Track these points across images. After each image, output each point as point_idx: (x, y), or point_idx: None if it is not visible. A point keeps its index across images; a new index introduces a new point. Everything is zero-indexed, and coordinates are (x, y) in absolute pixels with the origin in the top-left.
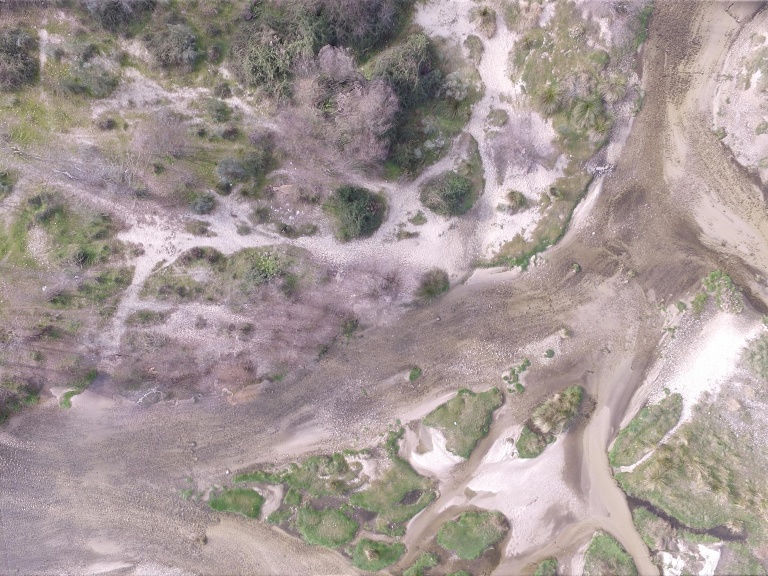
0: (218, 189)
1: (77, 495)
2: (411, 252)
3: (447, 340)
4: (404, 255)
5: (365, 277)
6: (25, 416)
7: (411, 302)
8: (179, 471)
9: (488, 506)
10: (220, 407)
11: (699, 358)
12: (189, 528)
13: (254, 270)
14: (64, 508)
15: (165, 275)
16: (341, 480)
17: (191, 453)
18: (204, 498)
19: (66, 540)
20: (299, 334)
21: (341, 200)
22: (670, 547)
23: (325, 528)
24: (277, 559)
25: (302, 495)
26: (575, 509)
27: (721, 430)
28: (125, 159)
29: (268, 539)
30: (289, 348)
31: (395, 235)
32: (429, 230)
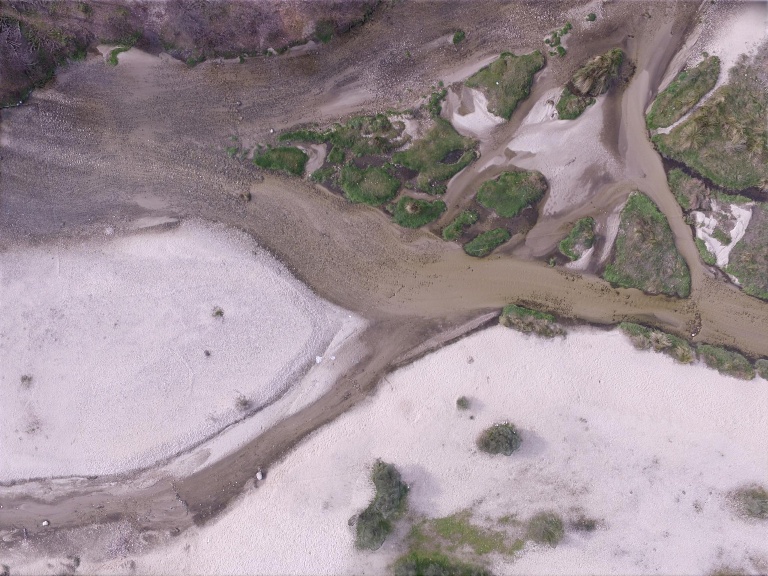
0: None
1: (123, 152)
2: None
3: (491, 4)
4: None
5: None
6: (71, 73)
7: None
8: (224, 130)
9: (527, 166)
10: (265, 68)
11: (738, 22)
12: (233, 185)
13: None
14: (110, 164)
15: None
16: (384, 138)
17: (236, 112)
18: (248, 156)
19: (111, 195)
20: None
21: None
22: (703, 205)
23: (367, 185)
24: (319, 216)
25: (345, 154)
26: (612, 170)
27: (757, 91)
28: None
29: (311, 197)
30: (335, 7)
31: None
32: None
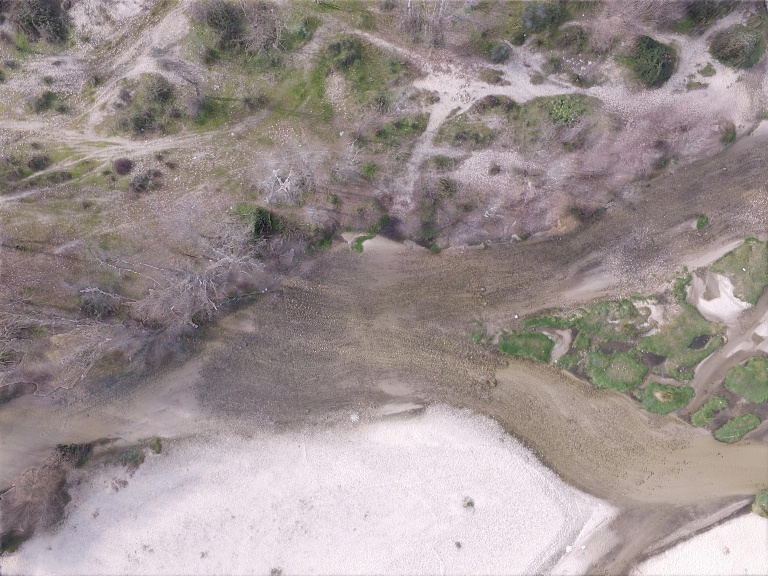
0: (513, 39)
1: (367, 338)
2: (700, 103)
3: (733, 190)
4: (693, 106)
5: (655, 127)
6: (316, 260)
7: (698, 152)
8: (468, 315)
9: None
10: (509, 253)
11: None
12: (478, 371)
13: (554, 114)
14: (354, 351)
15: (459, 122)
16: (631, 324)
17: (480, 298)
18: (493, 342)
19: (357, 382)
20: (591, 180)
21: (642, 46)
22: None
23: (615, 371)
24: (566, 402)
25: (591, 339)
26: None
27: None
28: (421, 9)
29: (556, 383)
30: (579, 195)
31: (685, 86)
32: (718, 82)
